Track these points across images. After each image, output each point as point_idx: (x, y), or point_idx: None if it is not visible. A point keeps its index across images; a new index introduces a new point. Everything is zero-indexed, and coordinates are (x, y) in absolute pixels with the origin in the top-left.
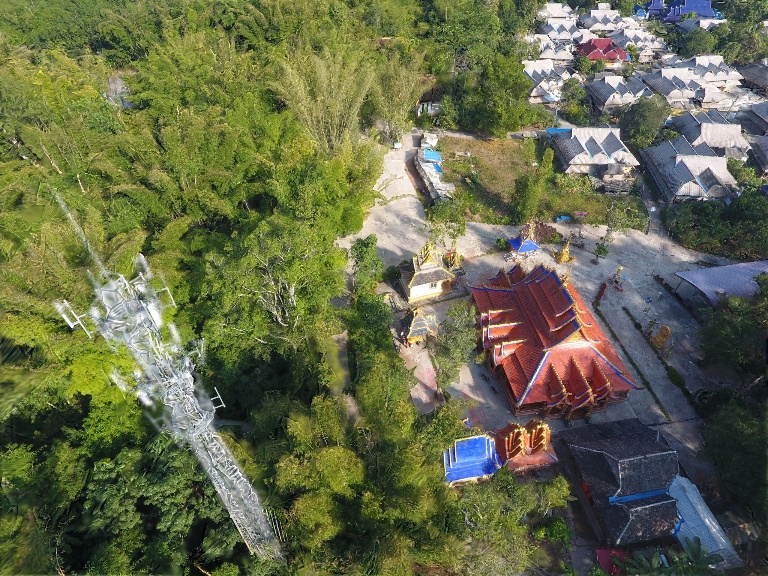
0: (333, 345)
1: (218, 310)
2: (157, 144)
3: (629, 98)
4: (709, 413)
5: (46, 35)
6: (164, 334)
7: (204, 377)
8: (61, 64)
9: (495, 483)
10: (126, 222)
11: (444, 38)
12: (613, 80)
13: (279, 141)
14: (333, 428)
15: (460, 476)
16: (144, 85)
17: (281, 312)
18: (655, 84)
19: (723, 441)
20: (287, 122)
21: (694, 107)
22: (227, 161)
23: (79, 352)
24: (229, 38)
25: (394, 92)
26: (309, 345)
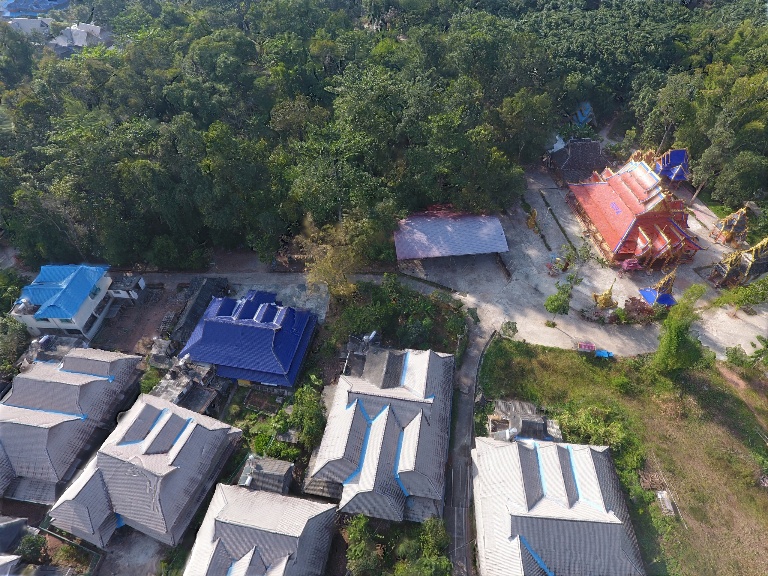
0: None
1: None
2: None
3: None
4: None
5: None
6: None
7: None
8: None
9: None
10: None
11: None
12: None
13: None
14: None
15: None
16: None
17: None
18: None
19: None
20: None
21: None
22: None
23: None
24: None
25: None
26: None
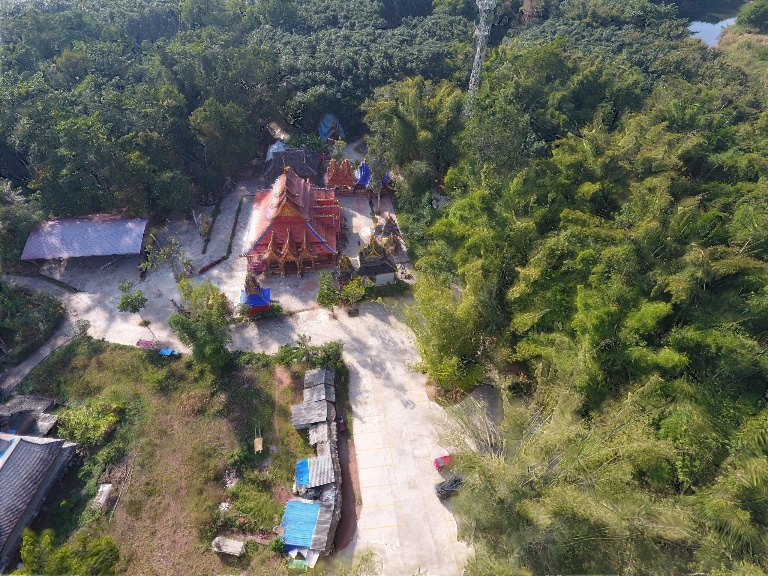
0: None
1: None
2: None
3: None
4: None
5: None
6: None
7: None
8: None
9: None
10: None
11: None
12: None
13: None
14: None
15: None
16: None
17: None
18: None
19: None
20: None
21: None
22: None
23: None
24: None
25: None
26: None
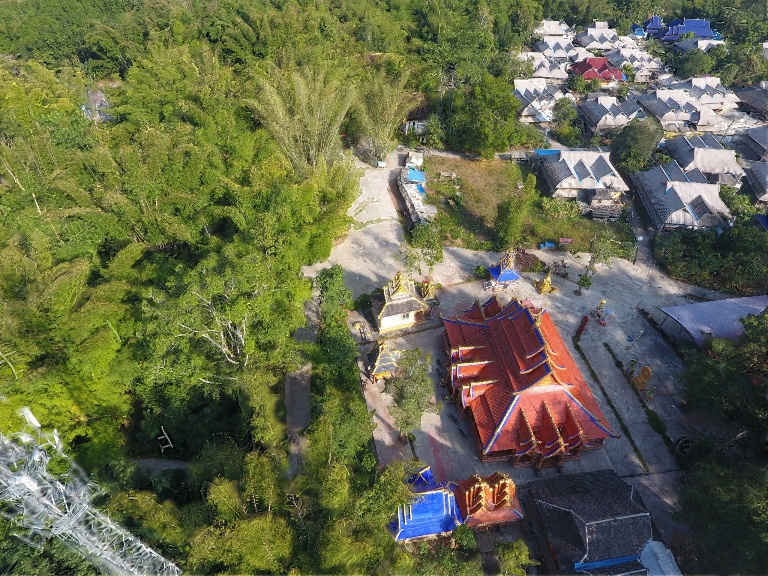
0: (296, 379)
1: (153, 352)
2: (116, 165)
3: (622, 119)
4: (690, 464)
5: (33, 44)
6: (14, 421)
7: (151, 414)
8: (39, 76)
9: (440, 557)
10: (78, 247)
11: (430, 57)
12: (606, 101)
13: (253, 160)
14: (266, 489)
15: (416, 533)
16: (122, 98)
17: (233, 348)
18: (649, 105)
19: (699, 505)
20: (262, 141)
21: (689, 130)
22: (193, 182)
23: (4, 393)
24: (213, 52)
25: (378, 110)
26: (240, 399)
